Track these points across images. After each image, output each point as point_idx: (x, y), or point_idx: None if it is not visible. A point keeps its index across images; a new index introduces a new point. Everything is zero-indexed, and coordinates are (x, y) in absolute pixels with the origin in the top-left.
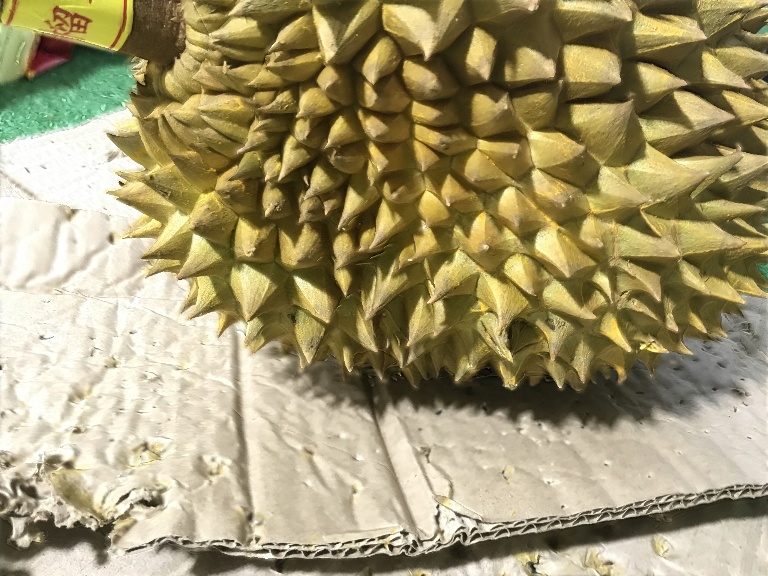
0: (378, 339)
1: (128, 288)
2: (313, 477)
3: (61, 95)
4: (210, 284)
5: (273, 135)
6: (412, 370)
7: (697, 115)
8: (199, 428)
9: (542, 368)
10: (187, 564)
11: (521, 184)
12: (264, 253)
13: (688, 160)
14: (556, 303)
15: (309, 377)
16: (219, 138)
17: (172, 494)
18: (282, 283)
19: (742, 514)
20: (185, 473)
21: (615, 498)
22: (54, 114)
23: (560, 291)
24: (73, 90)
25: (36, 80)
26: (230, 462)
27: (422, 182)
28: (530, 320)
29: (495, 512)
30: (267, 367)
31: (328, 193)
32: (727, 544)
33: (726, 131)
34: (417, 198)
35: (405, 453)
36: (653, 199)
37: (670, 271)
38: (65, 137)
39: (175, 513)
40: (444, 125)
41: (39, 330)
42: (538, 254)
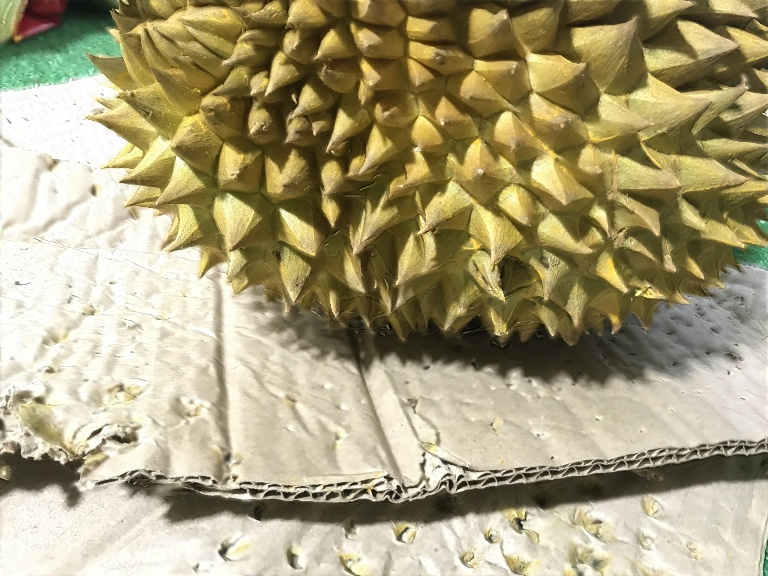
0: (366, 282)
1: (110, 240)
2: (295, 423)
3: (48, 57)
4: (192, 216)
5: (261, 49)
6: (400, 321)
7: (701, 44)
8: (178, 372)
9: (534, 315)
10: (162, 510)
11: (518, 108)
12: (249, 179)
13: (690, 94)
14: (551, 239)
15: (294, 331)
16: (204, 52)
17: (147, 431)
18: (267, 215)
19: (734, 477)
20: (161, 412)
21: (606, 451)
22: (40, 75)
23: (556, 226)
24: (60, 54)
25: (23, 43)
26: (209, 405)
27: (415, 106)
28: (524, 259)
29: (483, 461)
30: (251, 320)
31: (317, 114)
32: (718, 506)
33: (729, 69)
34: (410, 124)
35: (391, 404)
36: (654, 130)
37: (669, 209)
38: (49, 92)
39: (149, 448)
40: (440, 39)
41: (15, 276)
42: (534, 184)
